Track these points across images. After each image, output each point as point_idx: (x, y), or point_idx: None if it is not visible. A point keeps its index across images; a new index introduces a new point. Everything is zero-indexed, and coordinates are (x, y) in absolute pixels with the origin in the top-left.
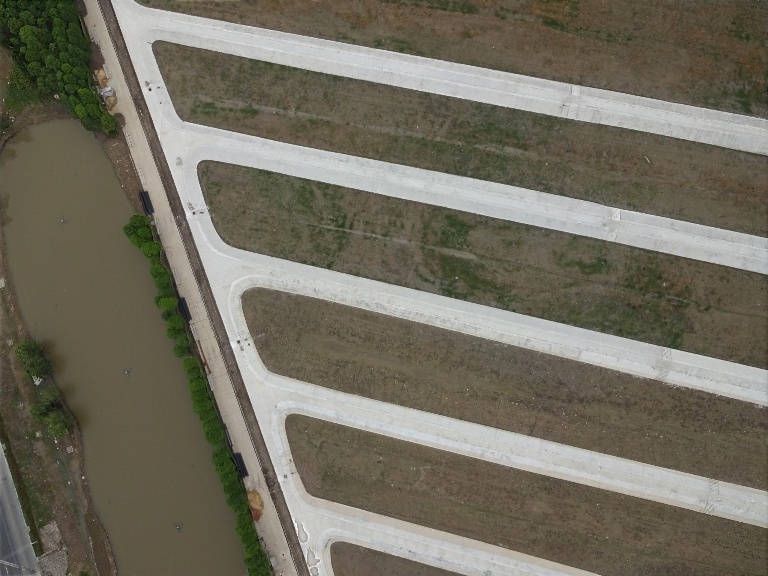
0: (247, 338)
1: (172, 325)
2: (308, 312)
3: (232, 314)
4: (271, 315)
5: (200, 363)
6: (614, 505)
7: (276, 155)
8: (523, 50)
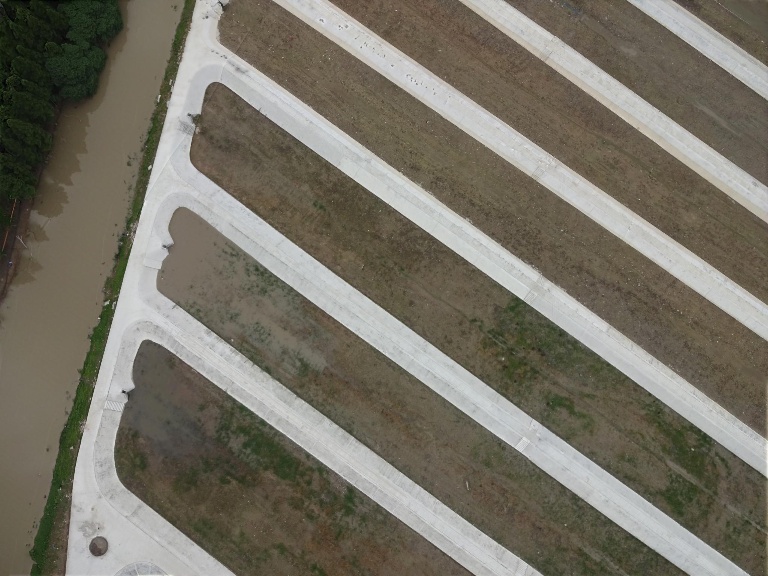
0: None
1: None
2: None
3: None
4: None
5: None
6: (626, 193)
7: None
8: None
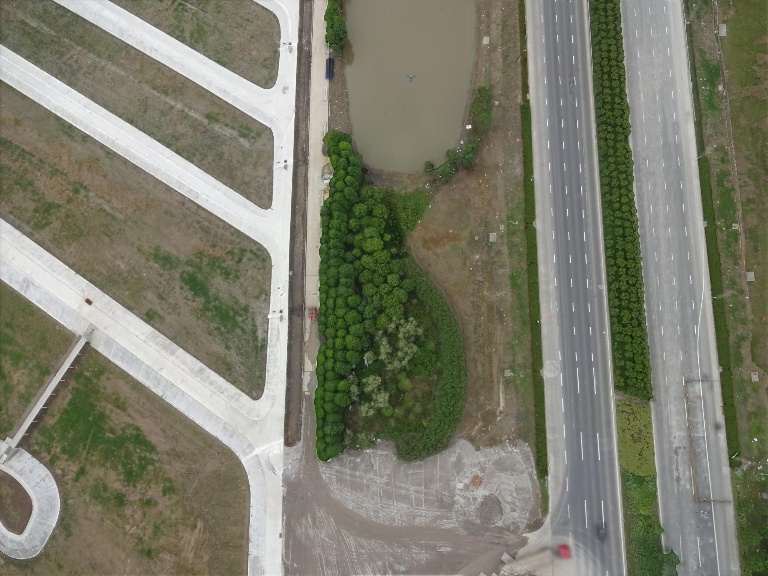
0: None
1: None
2: None
3: None
4: None
5: None
6: None
7: (203, 70)
8: None
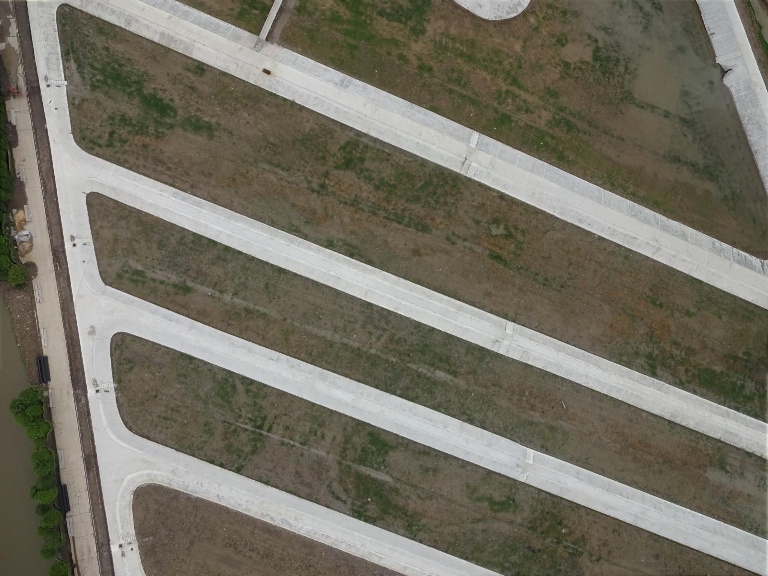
0: (131, 541)
1: (45, 524)
2: (206, 518)
3: (119, 512)
4: (164, 517)
5: (70, 565)
6: None
7: (203, 342)
8: (467, 278)
